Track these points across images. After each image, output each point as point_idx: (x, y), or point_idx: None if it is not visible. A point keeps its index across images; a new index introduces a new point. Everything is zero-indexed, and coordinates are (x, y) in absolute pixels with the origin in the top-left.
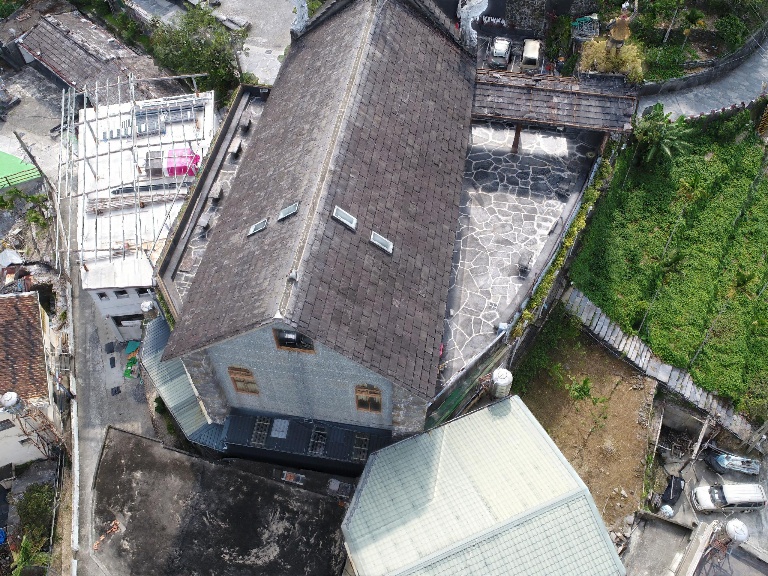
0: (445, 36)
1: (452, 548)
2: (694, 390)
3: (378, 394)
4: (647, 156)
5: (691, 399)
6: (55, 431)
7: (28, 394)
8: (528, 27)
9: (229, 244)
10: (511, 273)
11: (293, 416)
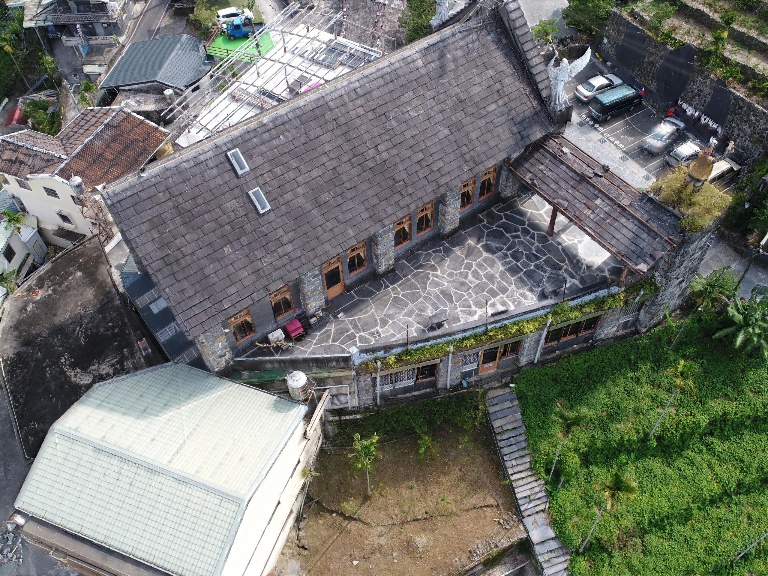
0: (532, 87)
1: (122, 451)
2: (561, 575)
3: None
4: (717, 332)
5: None
6: (108, 228)
7: None
8: (741, 147)
9: None
10: (422, 322)
11: None
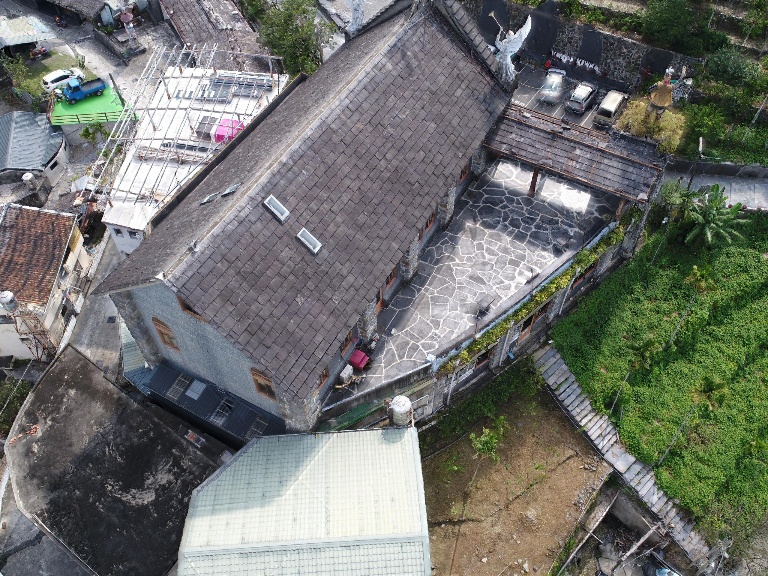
0: (481, 65)
1: (273, 545)
2: (653, 491)
3: (271, 382)
4: (687, 236)
5: (645, 499)
6: (48, 338)
7: (30, 299)
8: (620, 78)
9: (188, 208)
10: (470, 311)
11: (211, 382)
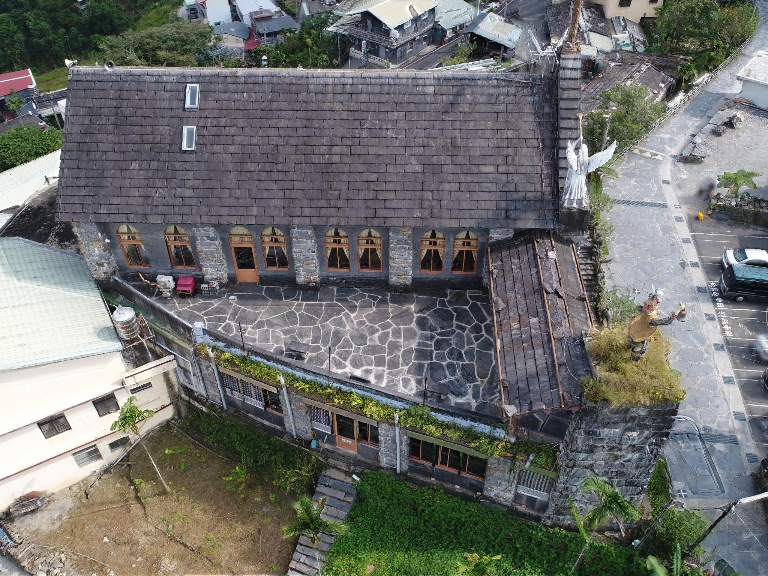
0: (554, 171)
1: None
2: None
3: None
4: None
5: None
6: None
7: None
8: None
9: None
10: None
11: None
